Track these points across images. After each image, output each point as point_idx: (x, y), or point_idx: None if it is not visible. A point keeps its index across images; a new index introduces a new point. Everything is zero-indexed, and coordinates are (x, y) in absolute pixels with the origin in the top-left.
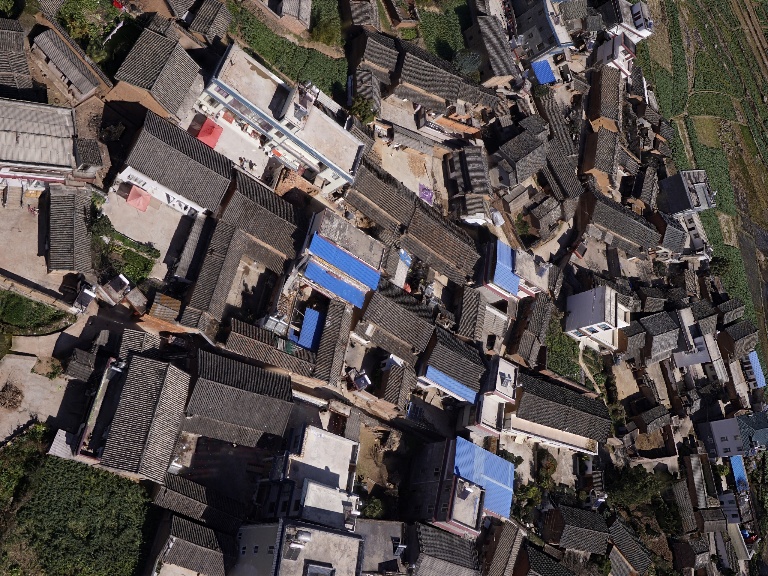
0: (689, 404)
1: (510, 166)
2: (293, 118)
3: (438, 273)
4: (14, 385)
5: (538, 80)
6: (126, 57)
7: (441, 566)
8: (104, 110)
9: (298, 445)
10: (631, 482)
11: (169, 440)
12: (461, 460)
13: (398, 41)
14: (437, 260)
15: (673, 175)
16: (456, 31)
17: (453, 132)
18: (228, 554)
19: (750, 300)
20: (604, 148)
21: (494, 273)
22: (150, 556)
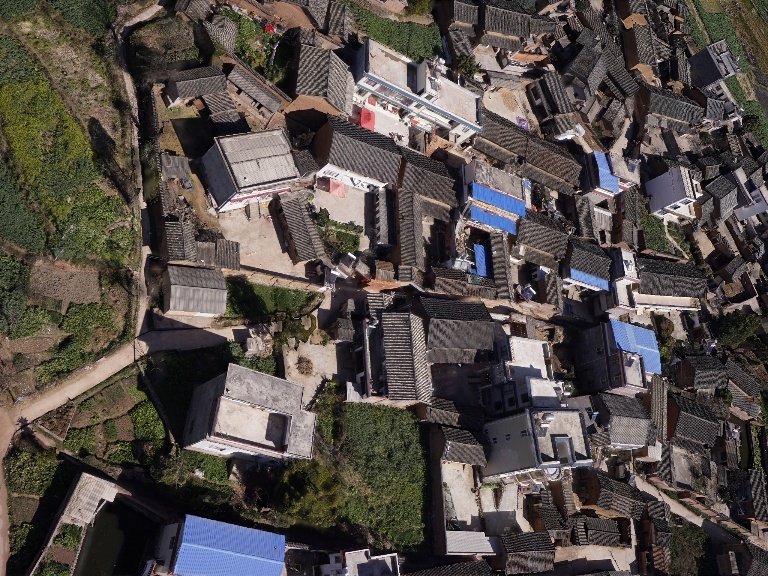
0: (756, 250)
1: (582, 82)
2: (431, 90)
3: (549, 190)
4: (304, 357)
5: None
6: (298, 73)
7: (626, 422)
8: (286, 121)
9: (508, 353)
10: (734, 325)
11: (425, 371)
12: (619, 337)
13: None
14: (550, 179)
15: (701, 51)
16: None
17: (527, 63)
18: (485, 446)
19: None
20: (642, 43)
21: (599, 179)
22: (431, 460)
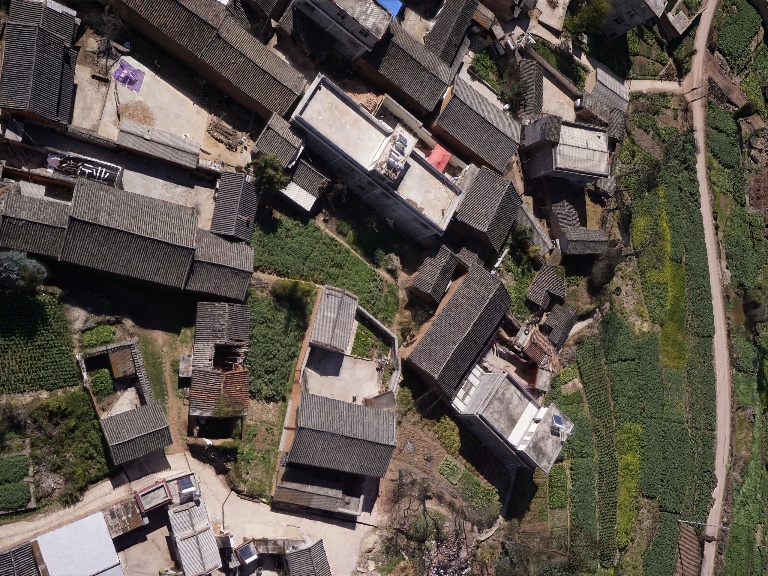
0: None
1: None
2: (408, 139)
3: None
4: (550, 7)
5: None
6: None
7: None
8: None
9: None
10: None
11: None
12: None
13: None
14: None
15: None
16: None
17: (29, 171)
18: None
19: None
20: None
21: None
22: None
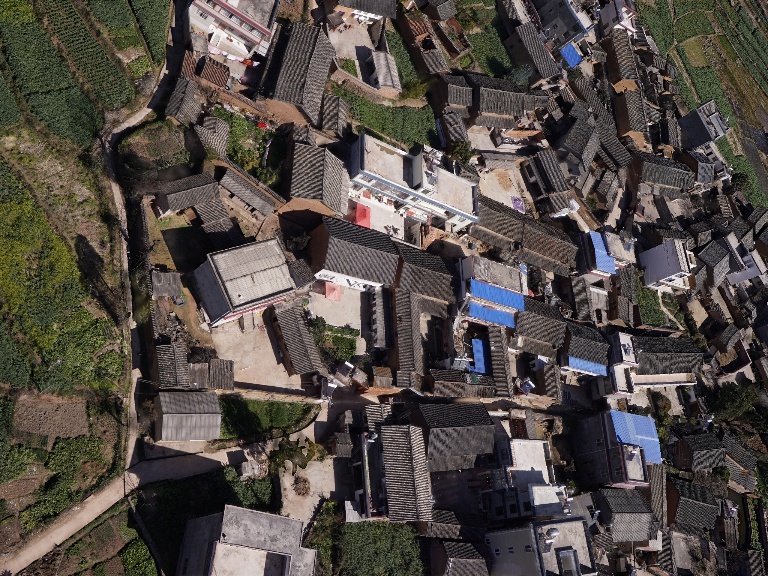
0: (748, 315)
1: (576, 158)
2: (428, 185)
3: (545, 271)
4: (300, 476)
5: (569, 65)
6: (292, 175)
7: (628, 518)
8: (280, 222)
9: (509, 457)
10: (730, 400)
11: (425, 485)
12: (619, 429)
13: (468, 77)
14: (546, 262)
15: (690, 114)
16: (498, 44)
17: (520, 139)
18: (488, 559)
19: (765, 201)
20: (634, 109)
21: (595, 261)
22: None
